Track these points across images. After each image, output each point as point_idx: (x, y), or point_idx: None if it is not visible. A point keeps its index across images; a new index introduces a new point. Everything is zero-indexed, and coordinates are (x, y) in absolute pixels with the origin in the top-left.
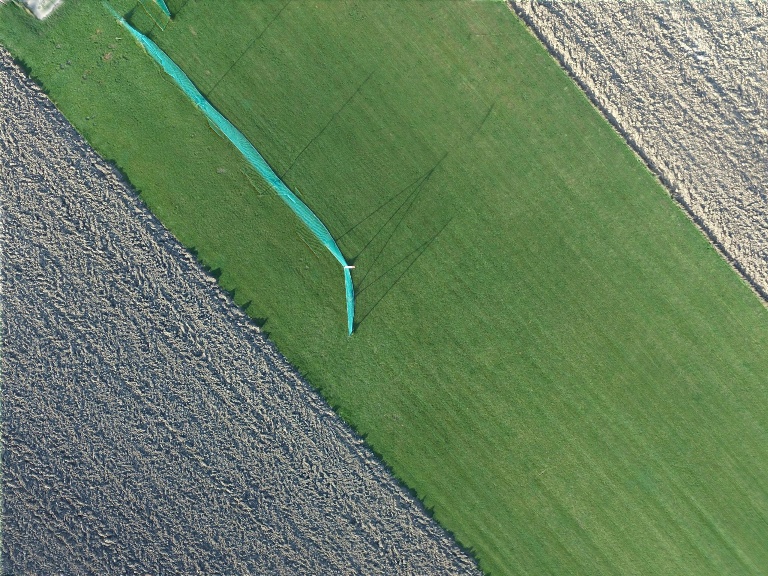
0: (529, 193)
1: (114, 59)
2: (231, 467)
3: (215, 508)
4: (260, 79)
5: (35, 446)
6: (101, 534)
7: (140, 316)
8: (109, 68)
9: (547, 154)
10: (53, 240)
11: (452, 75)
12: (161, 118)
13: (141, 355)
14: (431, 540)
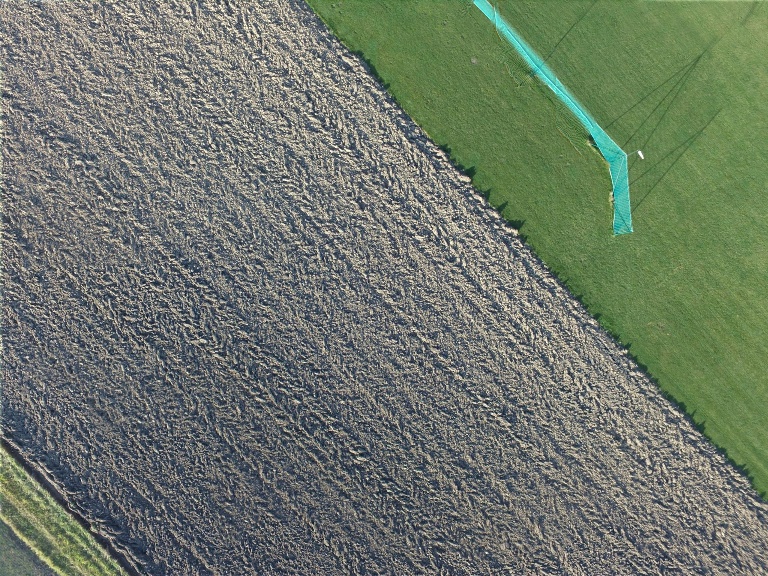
0: None
1: None
2: (488, 380)
3: (471, 424)
4: None
5: (283, 358)
6: (353, 451)
7: (390, 219)
8: None
9: None
10: (298, 139)
11: None
12: (412, 4)
13: (391, 261)
14: (703, 457)
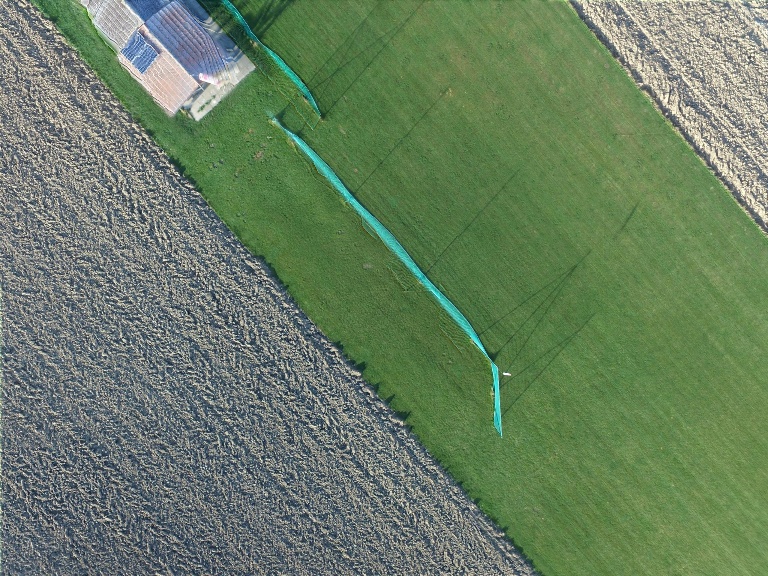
0: (673, 291)
1: (265, 158)
2: (373, 559)
3: None
4: (407, 177)
5: (183, 536)
6: None
7: (286, 409)
8: (260, 166)
9: (691, 252)
10: (203, 334)
11: (597, 174)
12: (309, 215)
13: (286, 447)
14: None
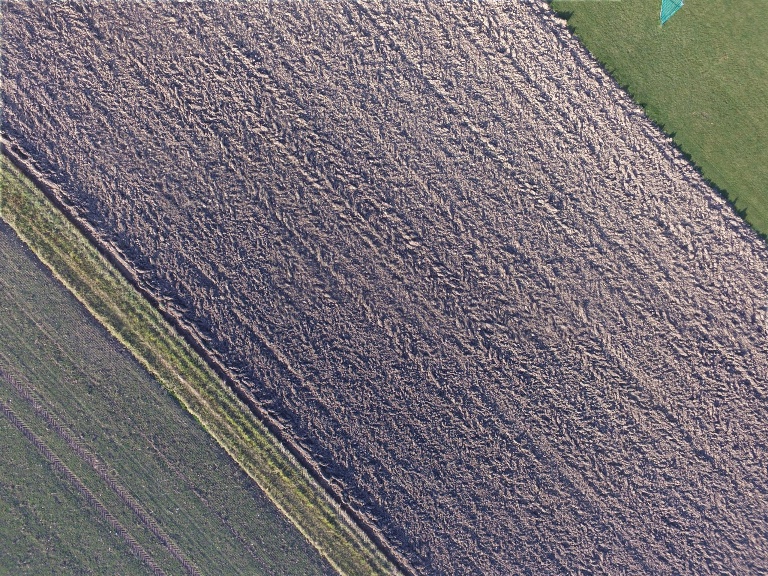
0: None
1: None
2: (535, 168)
3: (519, 211)
4: None
5: (339, 147)
6: (406, 235)
7: (443, 11)
8: None
9: None
10: None
11: None
12: None
13: (443, 53)
14: (744, 242)
